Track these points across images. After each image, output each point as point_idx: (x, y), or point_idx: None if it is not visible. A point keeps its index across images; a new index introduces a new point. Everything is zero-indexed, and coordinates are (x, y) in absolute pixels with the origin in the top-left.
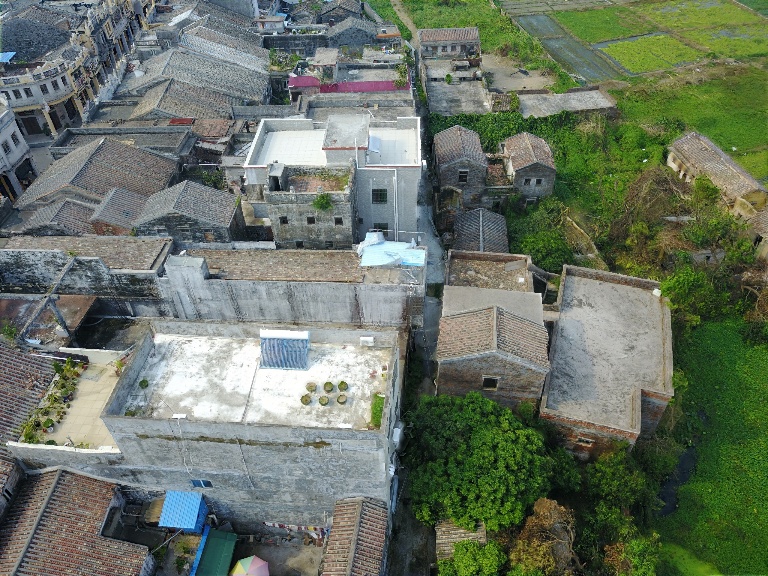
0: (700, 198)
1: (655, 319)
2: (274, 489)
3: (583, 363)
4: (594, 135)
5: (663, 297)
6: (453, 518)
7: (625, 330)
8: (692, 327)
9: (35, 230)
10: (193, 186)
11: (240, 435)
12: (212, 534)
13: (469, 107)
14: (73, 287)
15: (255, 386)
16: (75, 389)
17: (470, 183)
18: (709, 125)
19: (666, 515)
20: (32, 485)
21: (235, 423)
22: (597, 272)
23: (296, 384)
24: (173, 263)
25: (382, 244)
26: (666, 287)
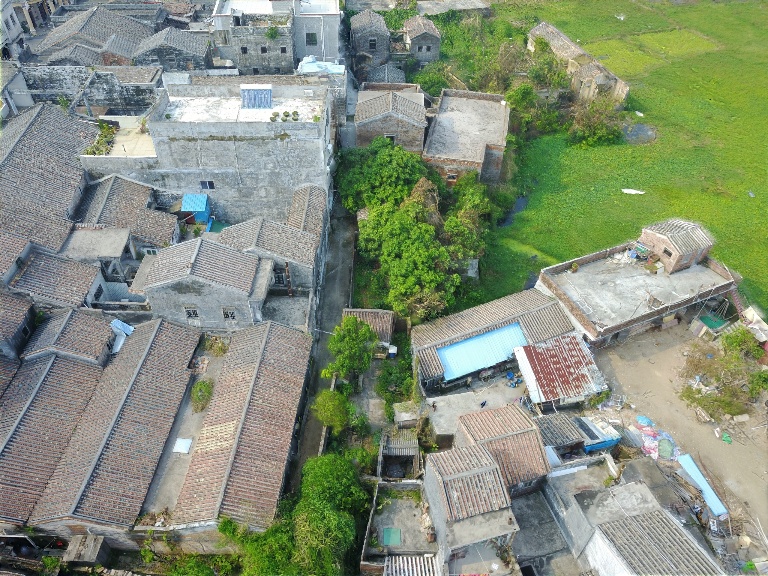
0: (537, 50)
1: (500, 116)
2: (254, 185)
3: (452, 137)
4: (473, 27)
5: (506, 103)
6: (367, 203)
7: (480, 121)
8: (525, 122)
9: (57, 62)
10: (175, 30)
11: (235, 132)
12: (215, 222)
13: (378, 8)
14: (92, 99)
15: (240, 116)
16: (114, 139)
17: (378, 50)
18: (562, 26)
19: (505, 226)
20: (95, 188)
21: (232, 122)
22: (464, 92)
23: (266, 114)
24: (168, 76)
25: (315, 63)
26: (507, 95)
